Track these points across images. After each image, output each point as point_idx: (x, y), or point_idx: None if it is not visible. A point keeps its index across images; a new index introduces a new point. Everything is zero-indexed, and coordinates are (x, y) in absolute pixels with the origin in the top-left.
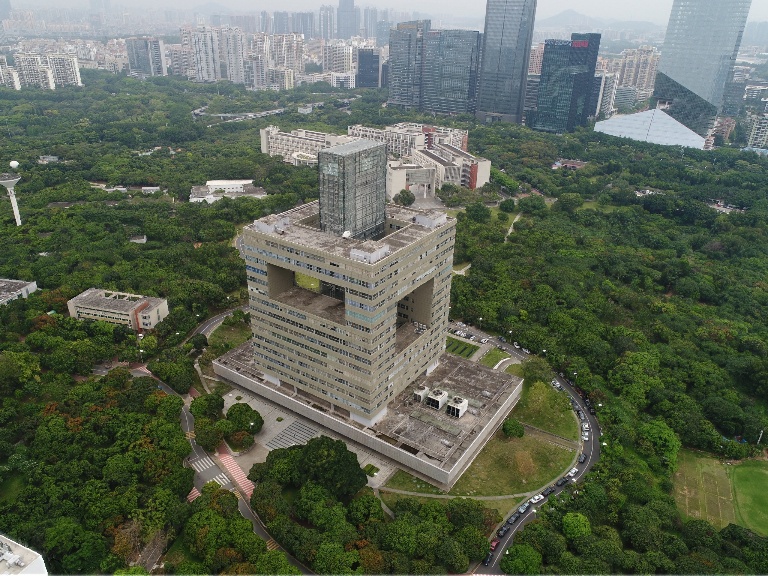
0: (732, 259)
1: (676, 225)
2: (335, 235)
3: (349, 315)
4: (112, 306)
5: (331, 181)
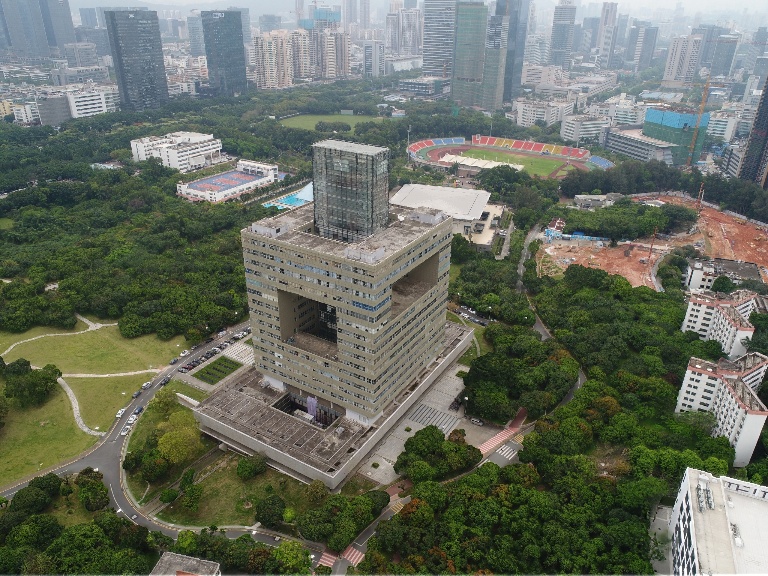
0: (161, 205)
1: (70, 208)
2: (384, 230)
3: (440, 272)
4: None
5: (382, 179)
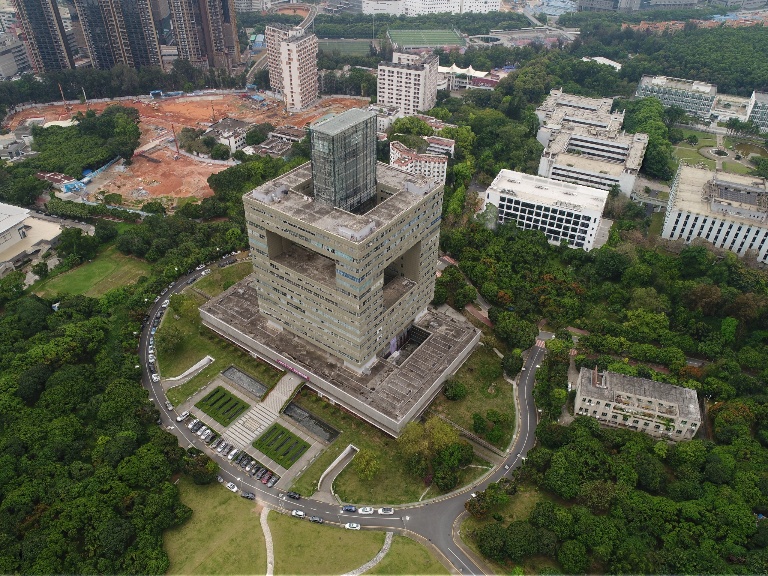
0: None
1: None
2: None
3: None
4: (635, 383)
5: None
